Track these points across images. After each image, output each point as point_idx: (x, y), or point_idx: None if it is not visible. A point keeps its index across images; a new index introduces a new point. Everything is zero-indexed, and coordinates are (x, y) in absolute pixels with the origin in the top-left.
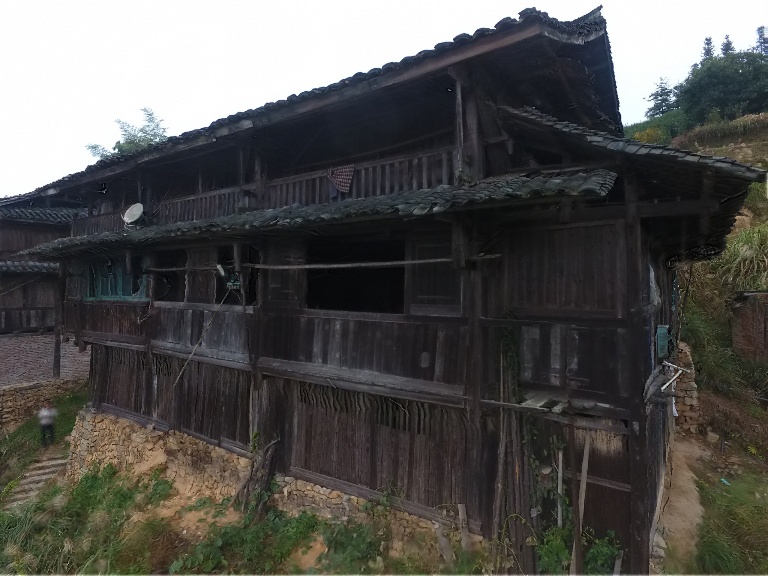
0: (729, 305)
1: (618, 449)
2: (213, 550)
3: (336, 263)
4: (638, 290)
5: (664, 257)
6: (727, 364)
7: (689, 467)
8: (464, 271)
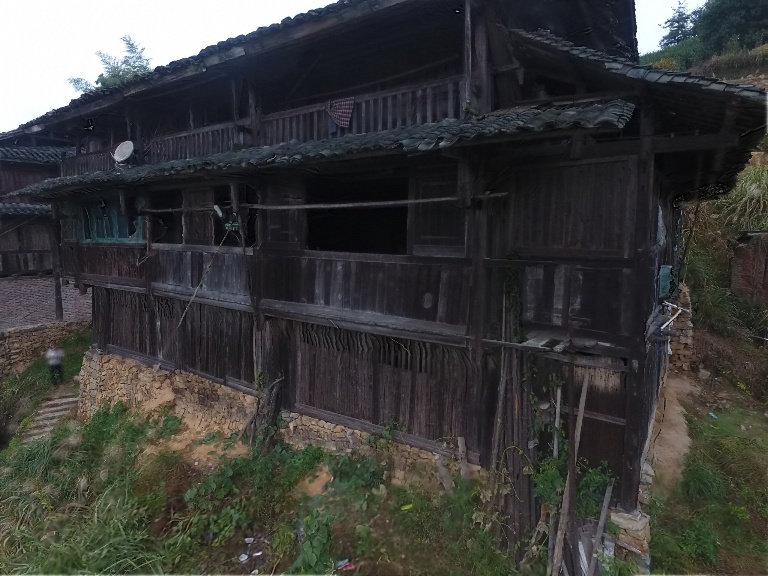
0: (731, 245)
1: (616, 386)
2: (225, 479)
3: (337, 203)
4: (647, 229)
5: (672, 196)
6: (724, 304)
7: (679, 402)
8: (469, 210)
